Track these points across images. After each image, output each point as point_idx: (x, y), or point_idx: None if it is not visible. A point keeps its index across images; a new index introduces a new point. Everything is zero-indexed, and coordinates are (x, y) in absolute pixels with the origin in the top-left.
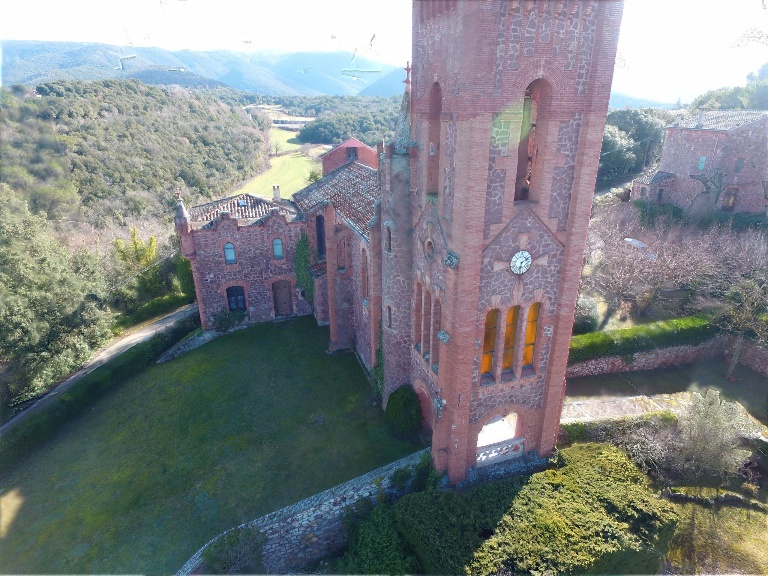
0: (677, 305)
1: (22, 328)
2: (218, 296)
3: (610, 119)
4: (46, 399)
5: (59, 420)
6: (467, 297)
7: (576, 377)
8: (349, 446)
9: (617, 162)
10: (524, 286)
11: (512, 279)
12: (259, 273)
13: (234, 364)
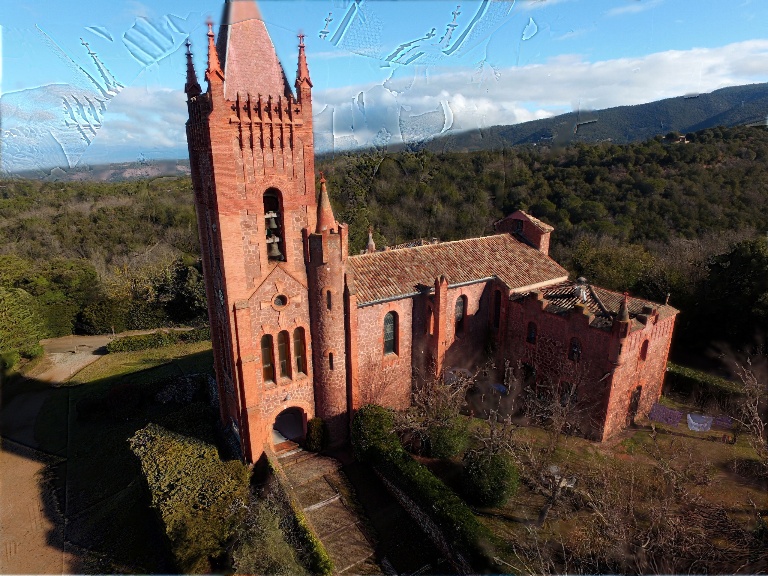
0: None
1: None
2: None
3: None
4: None
5: None
6: None
7: (404, 508)
8: None
9: None
10: None
11: None
12: None
13: None
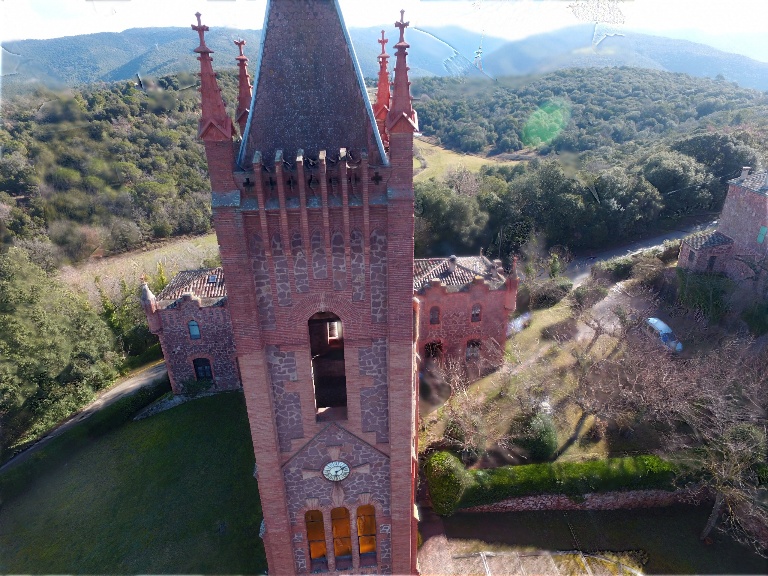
0: (675, 425)
1: (10, 392)
2: (186, 366)
3: (691, 145)
4: (42, 443)
5: (32, 476)
6: (271, 504)
7: (510, 512)
8: (229, 571)
9: (687, 201)
10: (346, 490)
11: (329, 484)
12: (223, 347)
13: (183, 440)
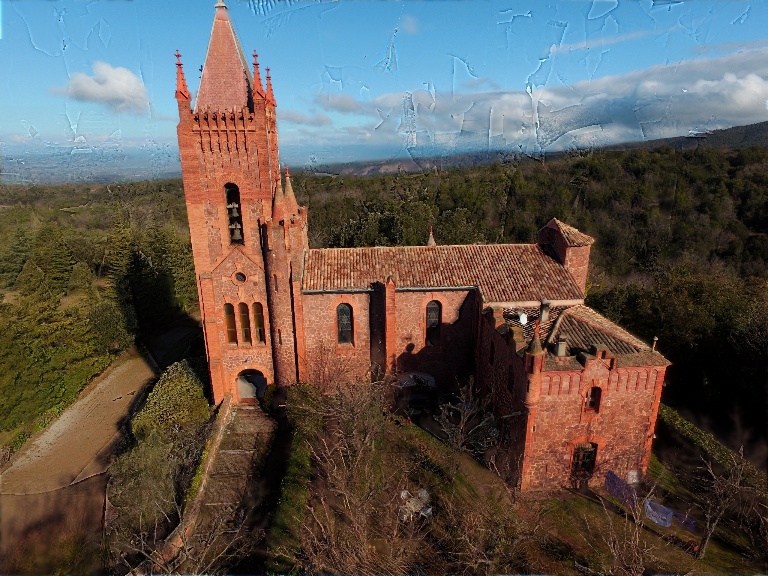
0: None
1: None
2: None
3: None
4: None
5: None
6: None
7: None
8: None
9: None
10: None
11: None
12: None
13: None
